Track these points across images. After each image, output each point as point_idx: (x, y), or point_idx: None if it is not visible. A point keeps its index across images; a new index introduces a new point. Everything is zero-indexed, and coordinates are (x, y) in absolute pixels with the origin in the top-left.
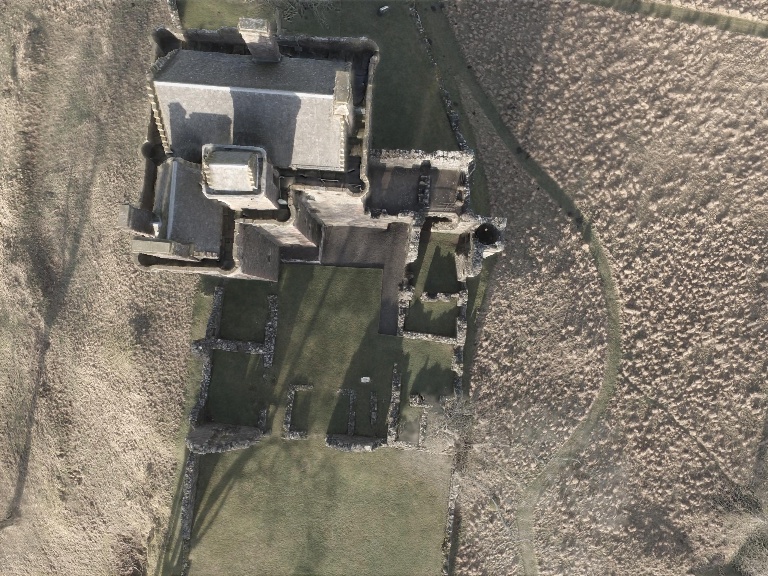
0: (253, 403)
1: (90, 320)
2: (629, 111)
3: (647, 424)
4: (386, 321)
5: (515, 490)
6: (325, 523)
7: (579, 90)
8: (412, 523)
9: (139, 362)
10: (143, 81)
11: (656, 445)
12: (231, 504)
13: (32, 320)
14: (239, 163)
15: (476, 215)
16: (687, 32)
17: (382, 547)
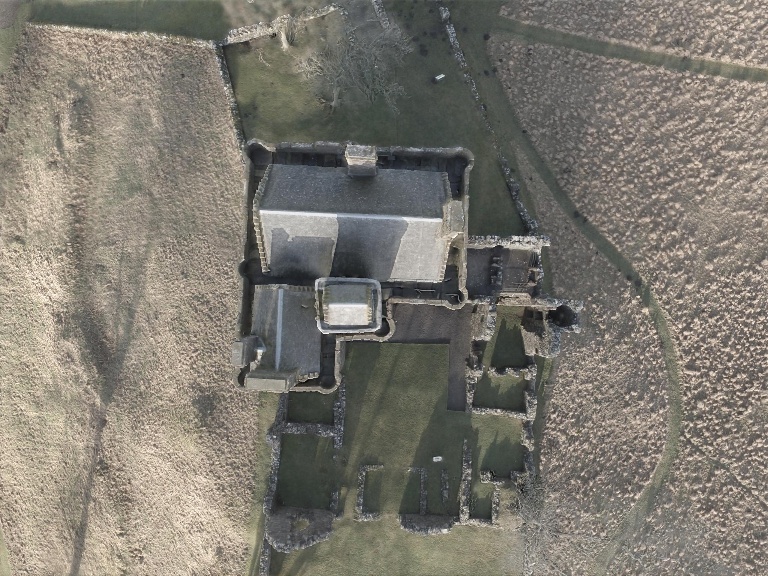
0: (324, 485)
1: (148, 398)
2: (683, 170)
3: (710, 485)
4: (454, 397)
5: (586, 561)
6: None
7: (633, 151)
8: None
9: (205, 445)
10: (197, 155)
11: (719, 506)
12: None
13: (87, 397)
14: (358, 301)
15: (553, 299)
16: (737, 89)
17: None
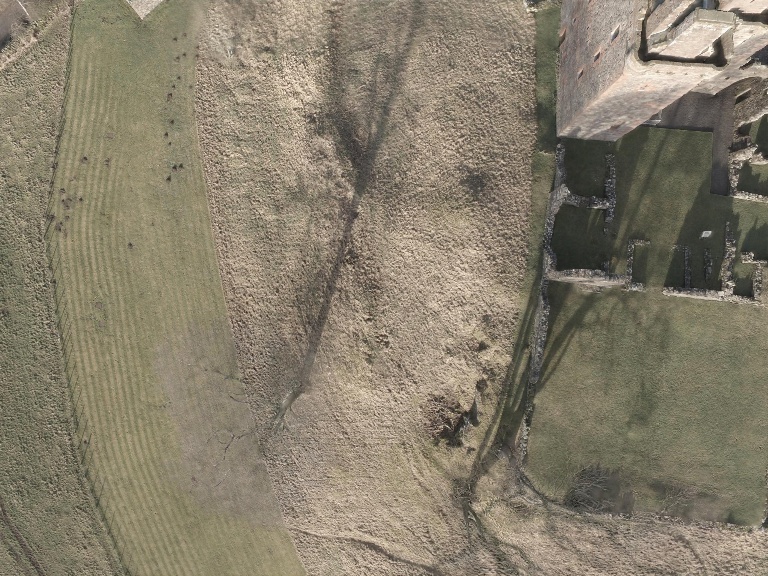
0: (594, 256)
1: (405, 187)
2: None
3: None
4: (716, 182)
5: None
6: (658, 374)
7: None
8: (745, 375)
9: (477, 218)
10: None
11: None
12: (572, 352)
13: (338, 191)
14: None
15: None
16: None
17: (714, 398)
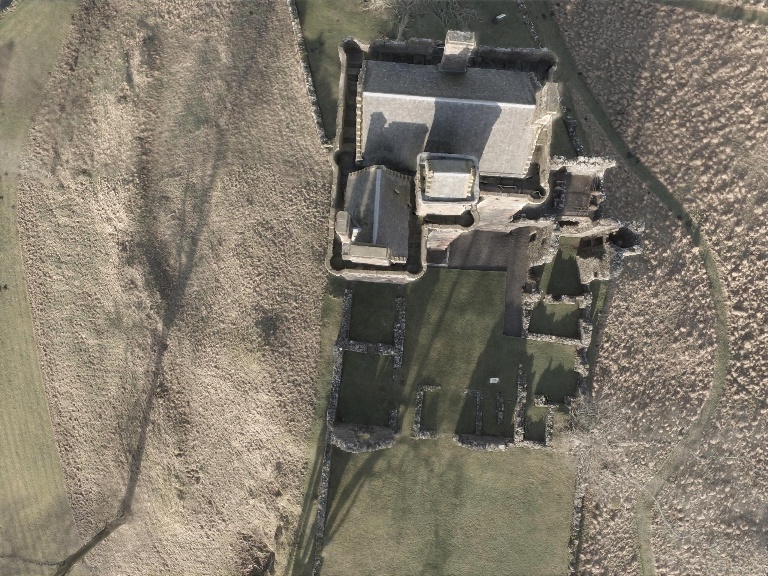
0: (383, 403)
1: (210, 322)
2: (734, 116)
3: (756, 424)
4: (510, 323)
5: (634, 489)
6: (452, 521)
7: (686, 96)
8: (538, 521)
9: (268, 363)
10: (264, 88)
11: (765, 445)
12: (362, 502)
13: (149, 322)
14: (460, 171)
15: None
16: None
17: (509, 545)
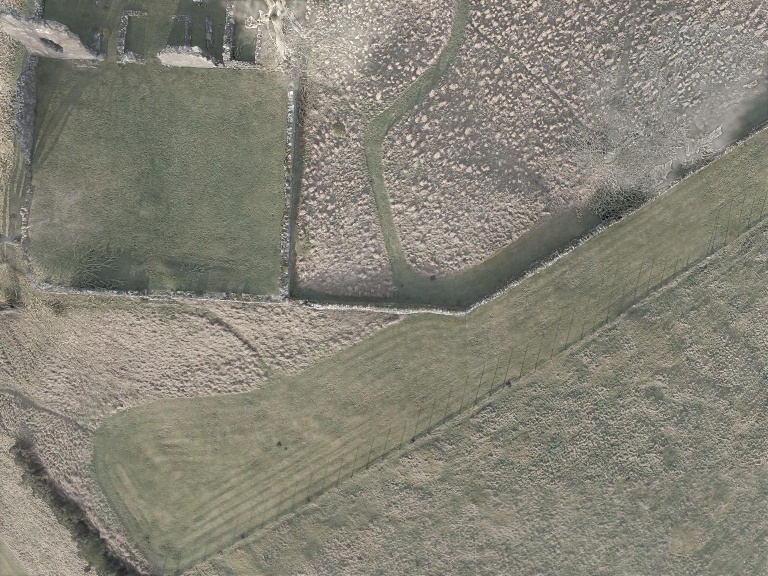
0: (87, 30)
1: None
2: None
3: (499, 72)
4: None
5: (360, 119)
6: (169, 150)
7: None
8: (254, 143)
9: None
10: None
11: (508, 93)
12: (71, 131)
13: None
14: None
15: None
16: None
17: (226, 169)
